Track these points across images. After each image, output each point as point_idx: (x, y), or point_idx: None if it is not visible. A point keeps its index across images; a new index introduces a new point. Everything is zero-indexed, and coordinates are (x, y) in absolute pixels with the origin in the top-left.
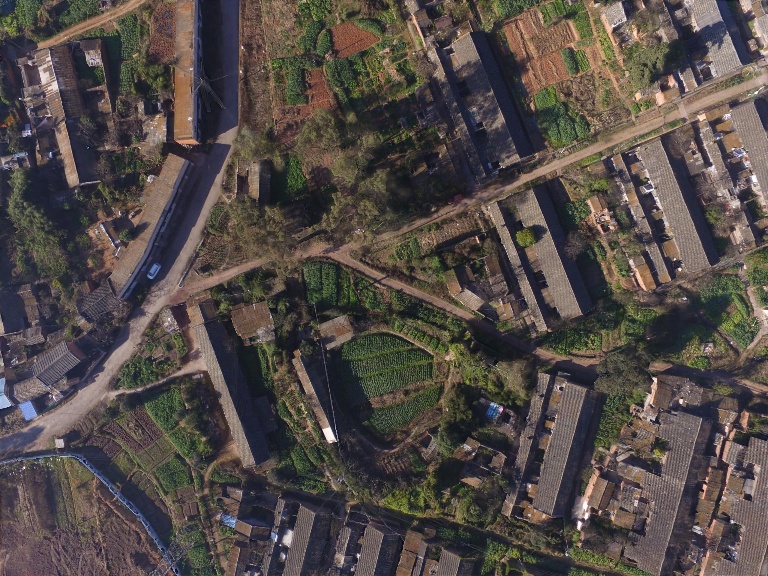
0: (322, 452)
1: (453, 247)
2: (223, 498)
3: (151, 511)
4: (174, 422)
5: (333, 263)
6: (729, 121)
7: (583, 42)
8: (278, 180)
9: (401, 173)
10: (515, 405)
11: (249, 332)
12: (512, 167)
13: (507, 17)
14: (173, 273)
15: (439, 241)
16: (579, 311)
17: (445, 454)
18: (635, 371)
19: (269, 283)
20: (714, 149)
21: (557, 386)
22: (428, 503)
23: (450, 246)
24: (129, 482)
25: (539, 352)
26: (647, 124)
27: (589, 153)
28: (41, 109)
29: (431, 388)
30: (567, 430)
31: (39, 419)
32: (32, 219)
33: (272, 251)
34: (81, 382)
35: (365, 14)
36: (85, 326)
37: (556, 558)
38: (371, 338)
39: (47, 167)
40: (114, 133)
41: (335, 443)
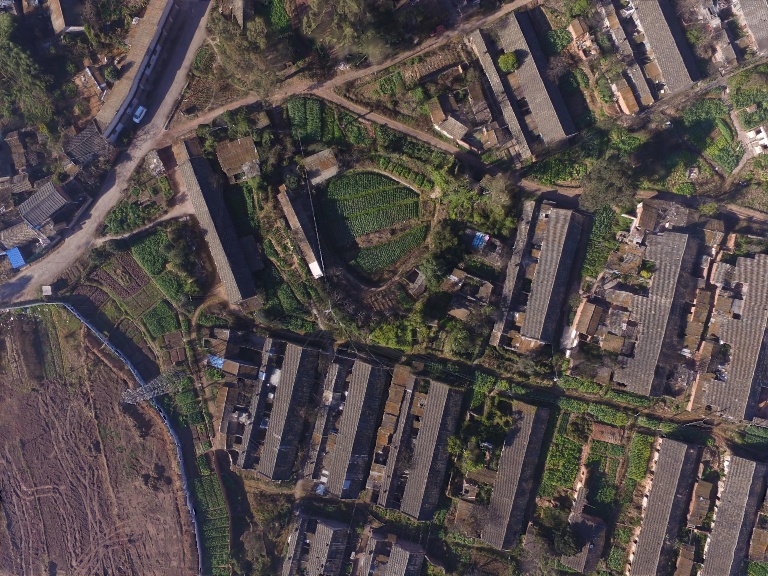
0: (309, 288)
1: (436, 78)
2: (210, 340)
3: (139, 359)
4: (161, 266)
5: (317, 99)
6: None
7: None
8: None
9: (383, 9)
10: (501, 235)
11: (234, 168)
12: None
13: None
14: (159, 117)
15: (422, 74)
16: (562, 133)
17: (432, 288)
18: (618, 173)
19: (254, 118)
20: None
21: (543, 214)
22: (416, 338)
23: (433, 76)
24: (117, 330)
25: (524, 184)
26: None
27: None
28: None
29: (417, 227)
30: (553, 254)
31: (27, 269)
32: (18, 60)
33: (253, 58)
34: (68, 230)
35: None
36: (72, 171)
37: (545, 389)
38: (356, 177)
39: (33, 15)
40: None
41: (321, 277)
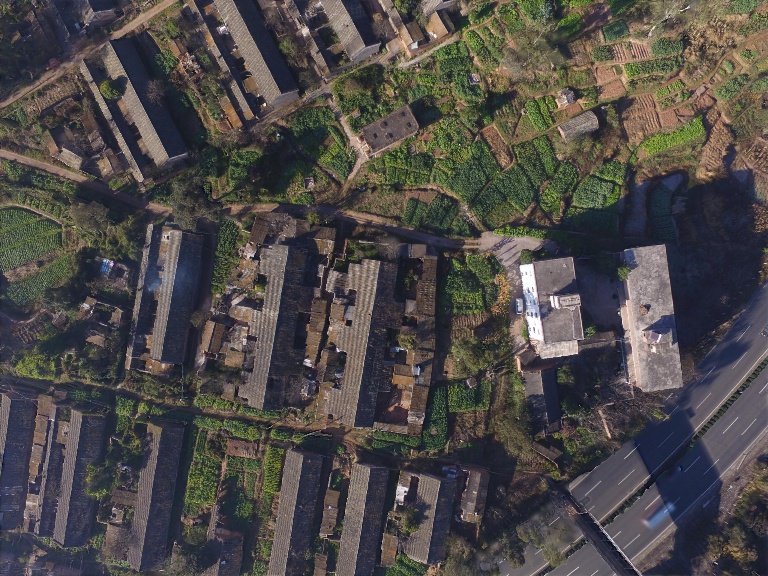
0: None
1: (53, 110)
2: None
3: None
4: None
5: None
6: None
7: None
8: None
9: (4, 46)
10: (130, 260)
11: None
12: (103, 26)
13: None
14: None
15: (43, 107)
16: (166, 155)
17: (72, 317)
18: (182, 194)
19: None
20: None
21: (165, 236)
22: (61, 368)
23: (48, 109)
24: None
25: (152, 207)
26: None
27: (171, 3)
28: None
29: (63, 257)
30: (170, 276)
31: None
32: None
33: None
34: None
35: None
36: None
37: (184, 409)
38: None
39: None
40: None
41: None
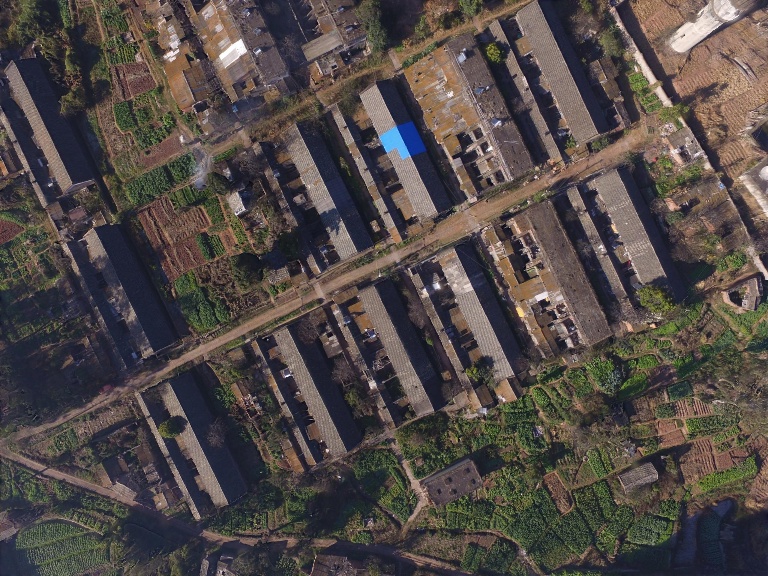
0: None
1: (106, 438)
2: None
3: None
4: None
5: None
6: (360, 302)
7: (215, 228)
8: None
9: (54, 363)
10: None
11: None
12: (160, 353)
13: (140, 205)
14: None
15: (95, 431)
16: (225, 501)
17: None
18: None
19: None
20: (346, 332)
21: (220, 571)
22: None
23: (102, 438)
24: None
25: (206, 534)
26: (286, 306)
27: (233, 337)
28: None
29: (111, 571)
30: None
31: None
32: None
33: None
34: None
35: (4, 207)
36: None
37: None
38: (44, 526)
39: None
40: None
41: None
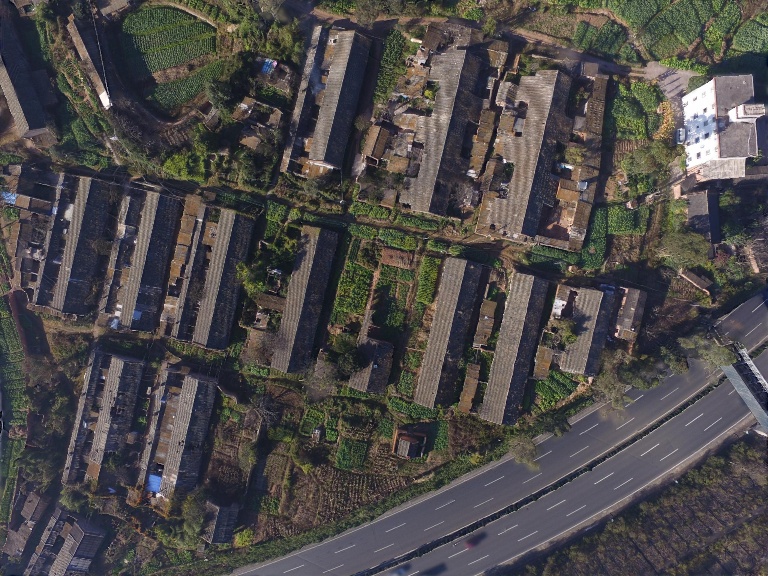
0: (100, 119)
1: None
2: (5, 177)
3: None
4: None
5: None
6: None
7: None
8: None
9: None
10: (292, 63)
11: None
12: None
13: None
14: None
15: None
16: None
17: (226, 120)
18: None
19: None
20: None
21: (331, 40)
22: (210, 170)
23: None
24: None
25: (317, 13)
26: None
27: None
28: None
29: (216, 62)
30: (338, 76)
31: None
32: None
33: None
34: None
35: None
36: None
37: (337, 217)
38: (152, 11)
39: None
40: None
41: (111, 107)
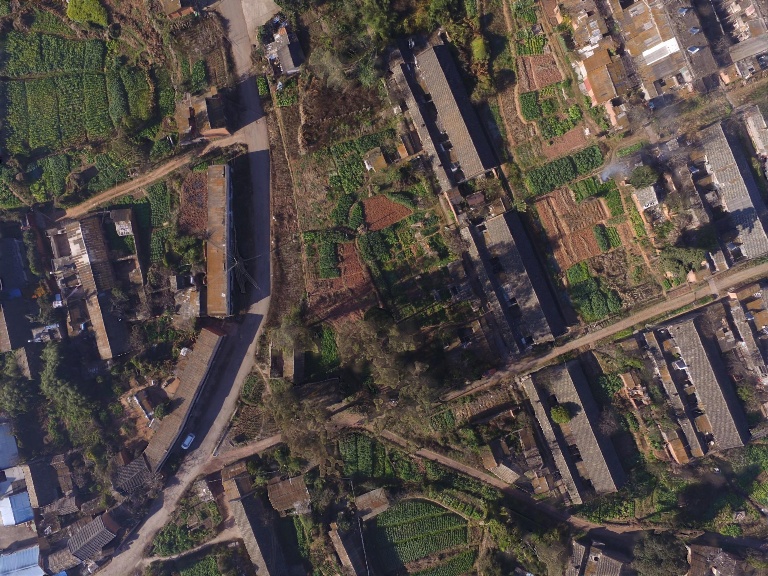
0: None
1: (488, 420)
2: None
3: None
4: None
5: None
6: (759, 300)
7: (614, 220)
8: (312, 352)
9: (434, 345)
10: None
11: (285, 506)
12: None
13: (539, 194)
14: (207, 442)
15: (473, 413)
16: (614, 487)
17: None
18: (674, 564)
19: (305, 458)
20: (745, 328)
21: (592, 556)
22: None
23: (485, 420)
24: None
25: (573, 520)
26: (678, 300)
27: (621, 327)
28: (71, 280)
29: (466, 552)
30: None
31: None
32: (66, 396)
33: (314, 454)
34: None
35: (397, 189)
36: (119, 497)
37: None
38: (406, 505)
39: (78, 338)
40: (146, 307)
41: None
